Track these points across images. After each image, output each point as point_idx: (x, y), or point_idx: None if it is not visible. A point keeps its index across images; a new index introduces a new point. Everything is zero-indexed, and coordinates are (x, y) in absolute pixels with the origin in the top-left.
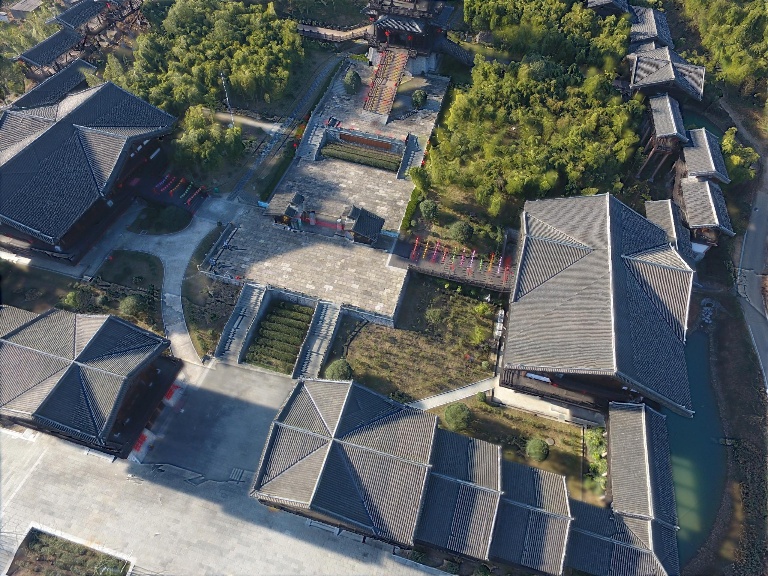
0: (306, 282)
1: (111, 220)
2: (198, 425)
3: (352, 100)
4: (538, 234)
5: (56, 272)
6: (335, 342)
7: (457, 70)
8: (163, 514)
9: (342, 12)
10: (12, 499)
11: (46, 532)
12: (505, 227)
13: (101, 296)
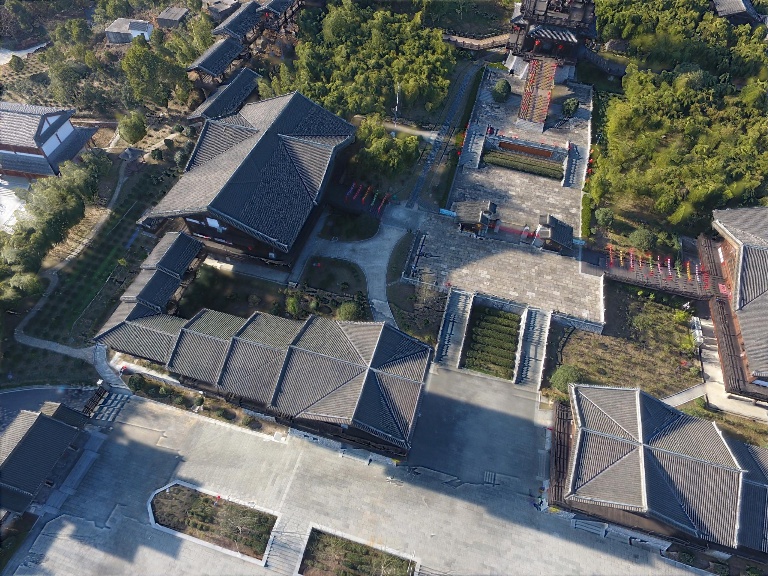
0: (508, 289)
1: (312, 227)
2: (438, 429)
3: (502, 108)
4: (751, 243)
5: (261, 278)
6: (547, 348)
7: (596, 78)
8: (432, 516)
9: (465, 20)
10: (285, 500)
11: (325, 532)
12: (679, 235)
13: (314, 302)
